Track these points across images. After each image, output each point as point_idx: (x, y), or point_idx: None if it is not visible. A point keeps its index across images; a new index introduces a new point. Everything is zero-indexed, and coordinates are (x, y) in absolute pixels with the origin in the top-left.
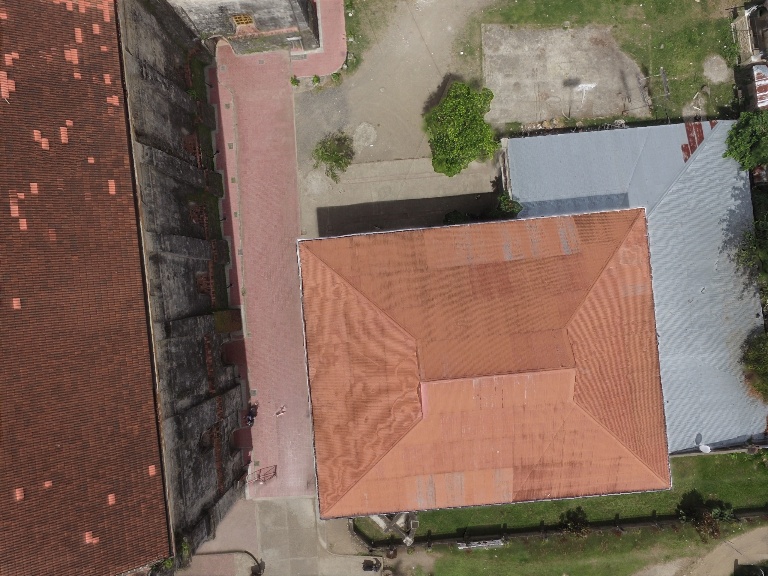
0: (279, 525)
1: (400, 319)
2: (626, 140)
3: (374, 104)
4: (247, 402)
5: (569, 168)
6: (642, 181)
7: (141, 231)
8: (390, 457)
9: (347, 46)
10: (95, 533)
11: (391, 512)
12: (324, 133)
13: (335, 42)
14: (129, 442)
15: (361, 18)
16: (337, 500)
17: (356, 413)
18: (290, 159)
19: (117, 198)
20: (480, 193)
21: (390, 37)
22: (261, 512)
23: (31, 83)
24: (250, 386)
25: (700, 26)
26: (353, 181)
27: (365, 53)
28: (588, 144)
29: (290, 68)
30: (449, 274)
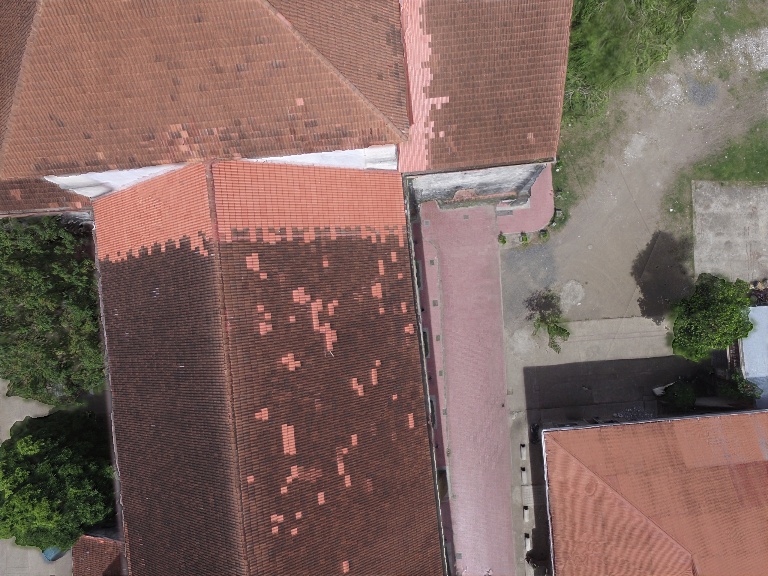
0: None
1: (670, 529)
2: None
3: (582, 261)
4: (453, 565)
5: None
6: None
7: (434, 461)
8: None
9: (554, 202)
10: None
11: None
12: (531, 291)
13: (542, 198)
14: None
15: (568, 173)
16: None
17: None
18: (496, 317)
19: (416, 431)
20: None
21: (598, 193)
22: None
23: (348, 329)
24: (455, 549)
25: None
26: None
27: (572, 209)
28: None
29: (496, 224)
30: (710, 475)
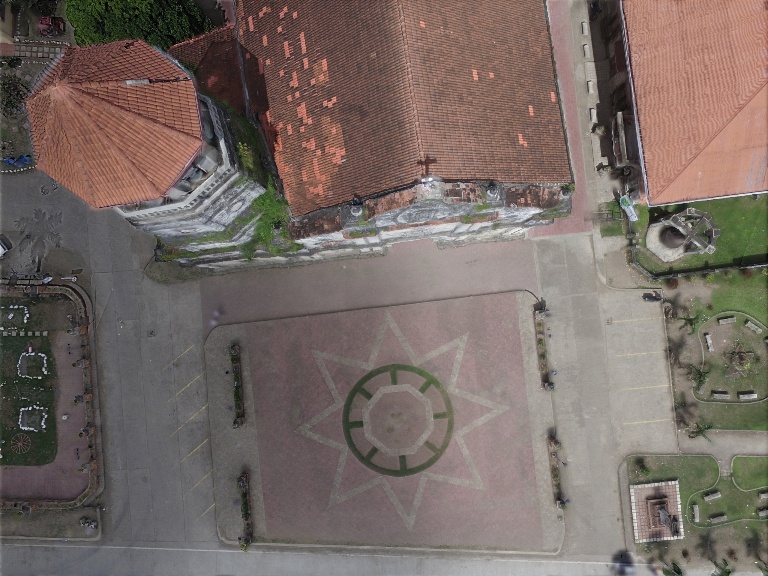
0: (558, 263)
1: None
2: None
3: None
4: None
5: None
6: None
7: None
8: (735, 123)
9: None
10: (524, 137)
11: (719, 195)
12: None
13: None
14: (536, 62)
15: None
16: (672, 180)
17: (692, 89)
18: None
19: None
20: None
21: None
22: (539, 251)
23: None
24: None
25: None
26: None
27: None
28: None
29: None
30: None
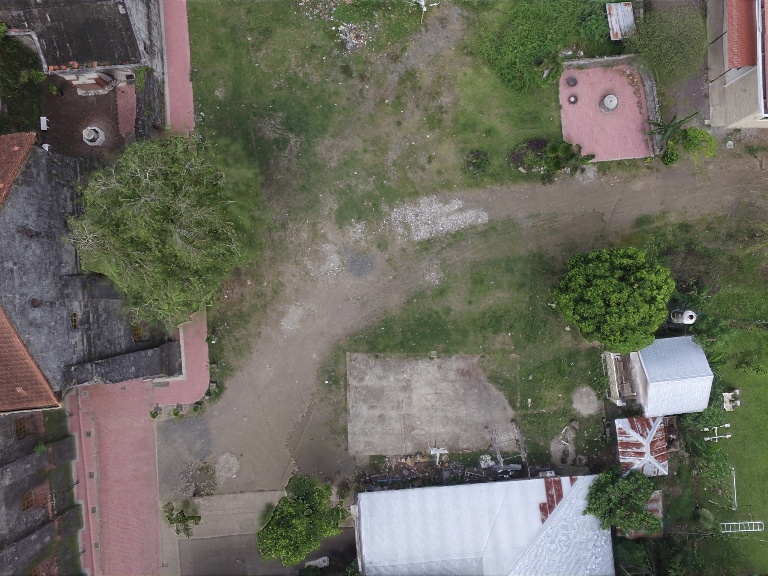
0: None
1: None
2: (484, 496)
3: (237, 433)
4: None
5: (424, 528)
6: (498, 544)
7: None
8: None
9: (210, 373)
10: None
11: None
12: (186, 463)
13: (198, 369)
14: None
15: (225, 345)
16: None
17: None
18: (151, 489)
19: None
20: (344, 527)
21: (254, 364)
22: None
23: None
24: None
25: (570, 356)
26: (215, 513)
27: (228, 381)
28: (445, 500)
29: (152, 395)
30: None
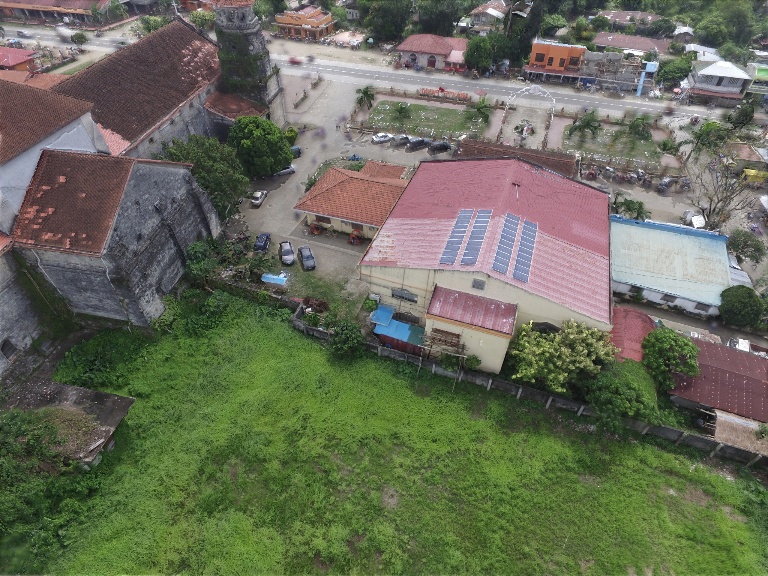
0: None
1: None
2: None
3: None
4: None
5: None
6: None
7: None
8: None
9: None
10: None
11: None
12: None
13: None
14: None
15: None
16: None
17: None
18: None
19: None
20: None
21: None
22: None
23: None
24: None
25: None
26: None
27: None
28: None
29: None
30: None
